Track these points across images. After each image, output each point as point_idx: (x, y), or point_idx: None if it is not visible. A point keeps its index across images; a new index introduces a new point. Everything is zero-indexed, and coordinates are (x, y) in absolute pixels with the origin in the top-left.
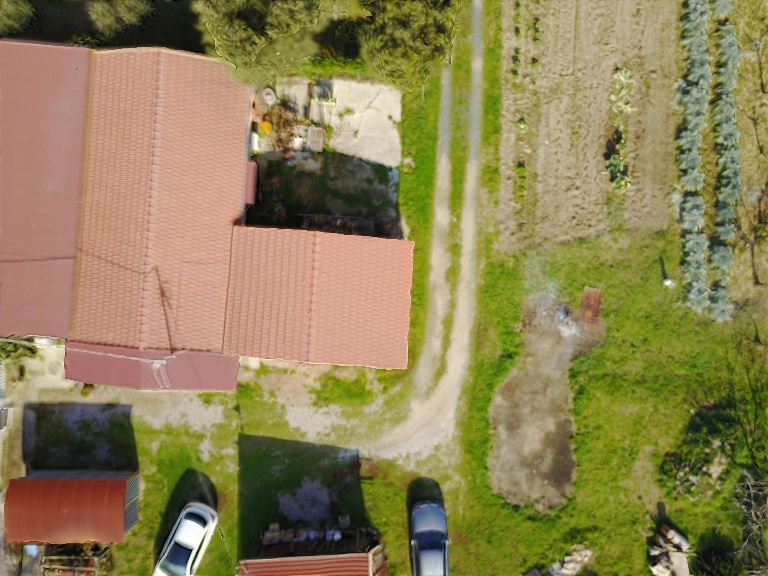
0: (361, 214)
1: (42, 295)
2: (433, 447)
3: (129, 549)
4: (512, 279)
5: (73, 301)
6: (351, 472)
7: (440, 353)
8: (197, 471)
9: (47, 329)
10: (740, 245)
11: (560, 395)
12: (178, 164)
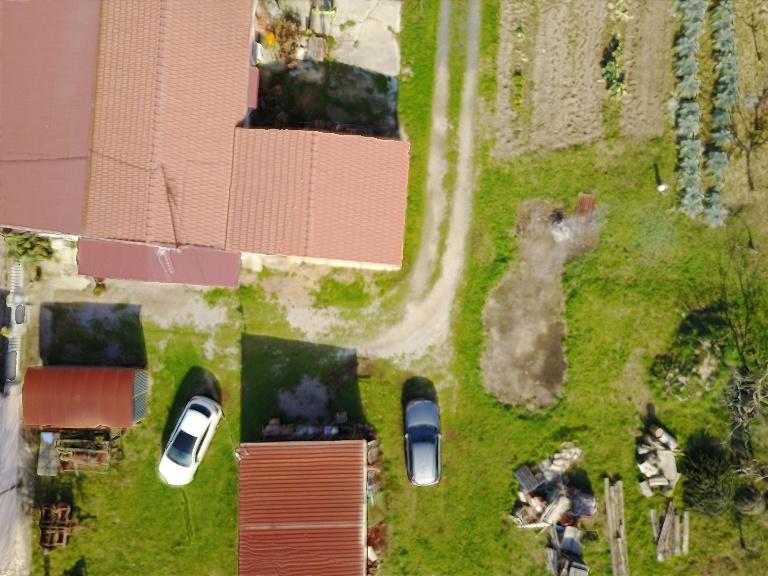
0: (360, 122)
1: (55, 193)
2: (428, 348)
3: (139, 440)
4: (507, 186)
5: (84, 199)
6: (349, 371)
7: (436, 257)
8: (202, 368)
9: (60, 225)
10: (736, 152)
11: (553, 299)
12: (182, 66)
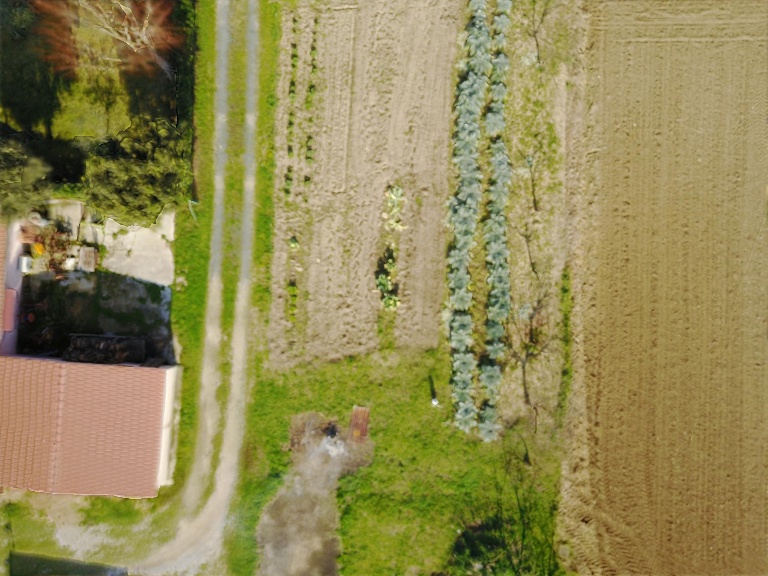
0: (133, 333)
1: None
2: (201, 566)
3: None
4: (282, 398)
5: None
6: None
7: (210, 471)
8: None
9: None
10: (511, 363)
11: (328, 514)
12: None
